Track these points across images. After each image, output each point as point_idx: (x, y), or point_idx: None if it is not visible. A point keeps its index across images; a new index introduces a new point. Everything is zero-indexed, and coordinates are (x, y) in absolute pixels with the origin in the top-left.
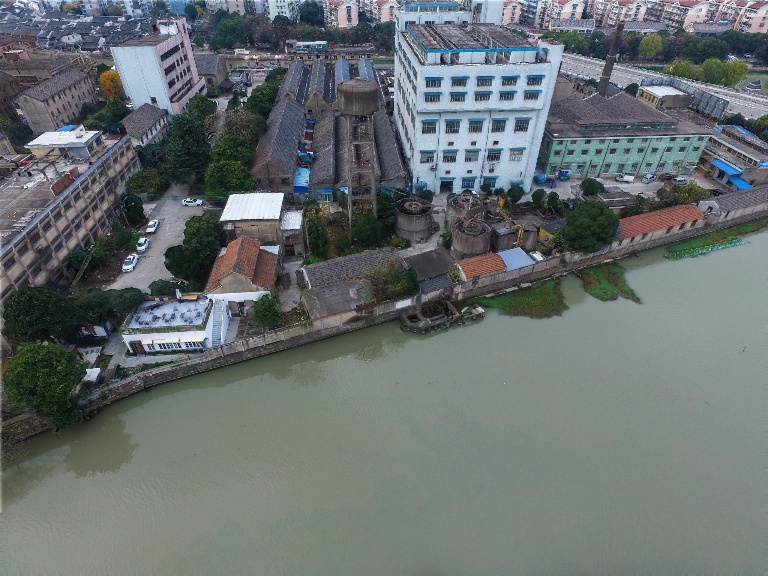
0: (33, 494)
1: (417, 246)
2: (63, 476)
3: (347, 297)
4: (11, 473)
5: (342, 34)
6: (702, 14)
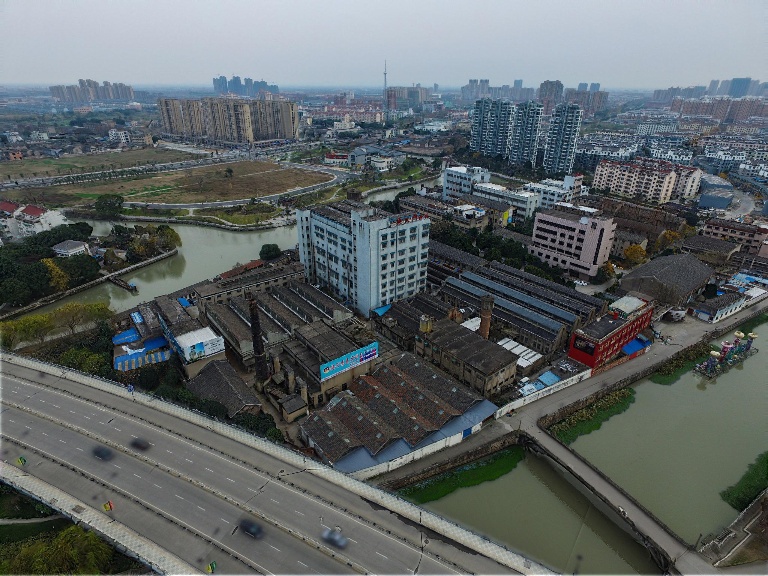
0: None
1: None
2: None
3: None
4: None
5: None
6: None
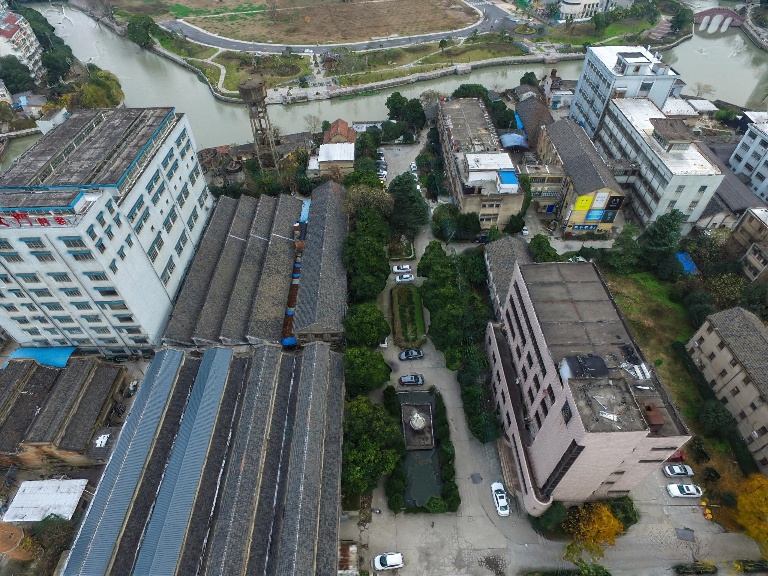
0: None
1: None
2: None
3: None
4: None
5: None
6: None
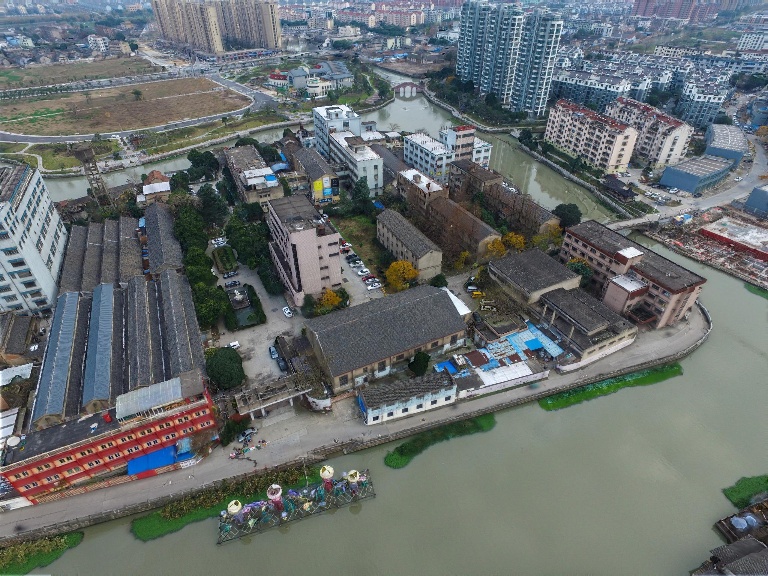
0: None
1: None
2: None
3: None
4: None
5: None
6: None
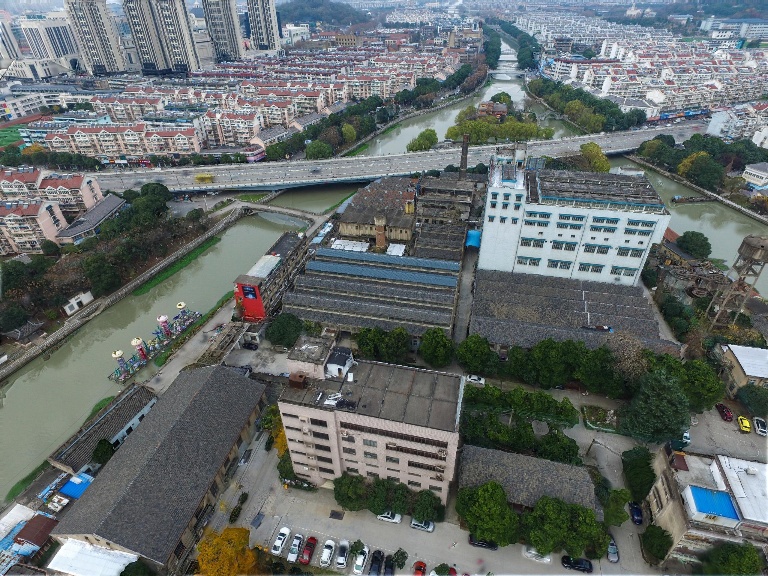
0: None
1: None
2: None
3: None
4: None
5: (143, 243)
6: (322, 99)
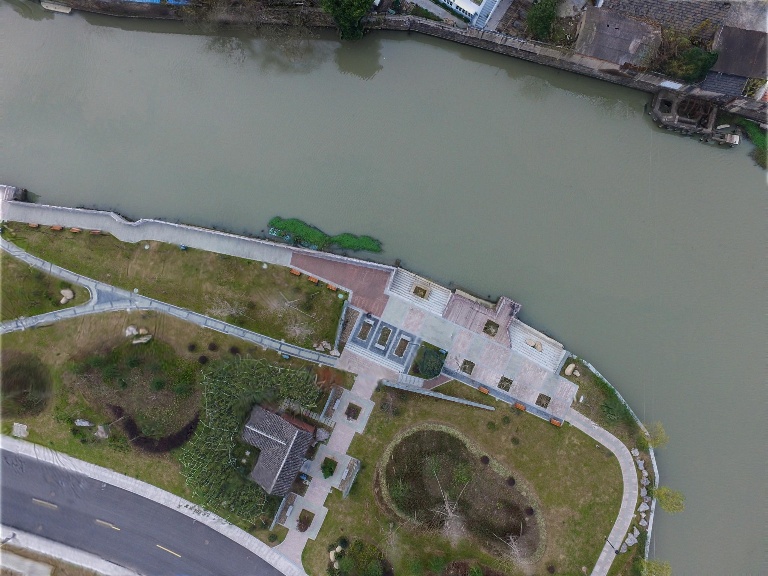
0: (314, 72)
1: (763, 3)
2: (332, 65)
3: (625, 47)
4: (304, 45)
5: None
6: None
